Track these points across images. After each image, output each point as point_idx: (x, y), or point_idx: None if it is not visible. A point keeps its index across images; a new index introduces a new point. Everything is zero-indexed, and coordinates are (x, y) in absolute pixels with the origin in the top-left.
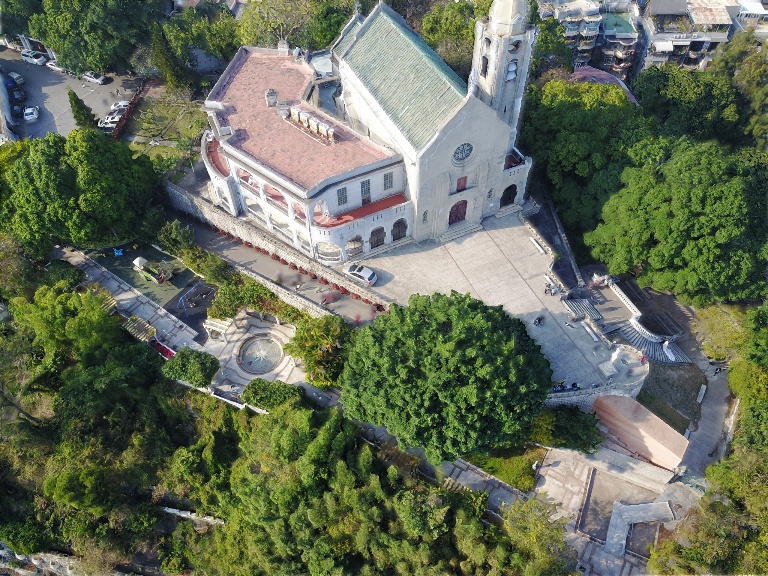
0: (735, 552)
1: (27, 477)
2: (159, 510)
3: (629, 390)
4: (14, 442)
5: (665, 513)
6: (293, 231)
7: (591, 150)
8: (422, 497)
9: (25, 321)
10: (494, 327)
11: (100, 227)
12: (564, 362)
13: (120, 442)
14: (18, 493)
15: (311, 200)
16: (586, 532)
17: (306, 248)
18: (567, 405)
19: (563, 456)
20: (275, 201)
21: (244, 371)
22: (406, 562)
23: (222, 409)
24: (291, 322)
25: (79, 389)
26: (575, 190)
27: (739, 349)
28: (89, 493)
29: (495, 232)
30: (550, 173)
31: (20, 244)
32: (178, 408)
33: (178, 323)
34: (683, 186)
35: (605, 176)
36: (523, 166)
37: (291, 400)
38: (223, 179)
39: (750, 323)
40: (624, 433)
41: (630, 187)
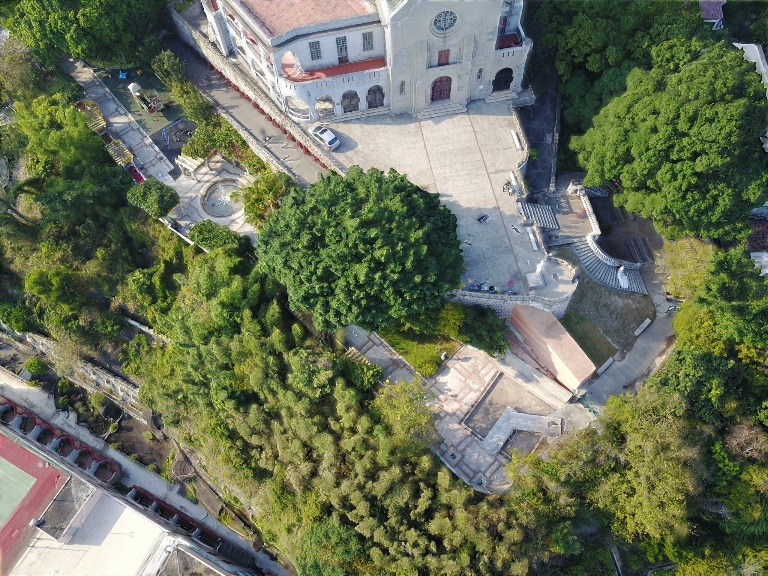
0: (597, 477)
1: (18, 266)
2: (124, 320)
3: (549, 305)
4: (1, 233)
5: (553, 428)
6: (268, 80)
7: (609, 42)
8: (314, 357)
9: (20, 126)
10: (414, 213)
11: (100, 46)
12: (494, 264)
13: (89, 253)
14: (13, 279)
15: (275, 49)
16: (471, 426)
17: (280, 100)
18: (484, 306)
19: (475, 354)
20: (254, 45)
21: (205, 211)
22: (288, 409)
23: (174, 242)
24: (254, 173)
25: (51, 197)
26: (582, 86)
27: (695, 290)
28: (55, 290)
29: (478, 118)
30: (557, 62)
31: (28, 51)
32: (141, 233)
33: (159, 154)
34: (675, 99)
35: (614, 75)
36: (520, 48)
37: (228, 246)
38: (211, 13)
39: (710, 265)
40: (536, 346)
41: (627, 91)
